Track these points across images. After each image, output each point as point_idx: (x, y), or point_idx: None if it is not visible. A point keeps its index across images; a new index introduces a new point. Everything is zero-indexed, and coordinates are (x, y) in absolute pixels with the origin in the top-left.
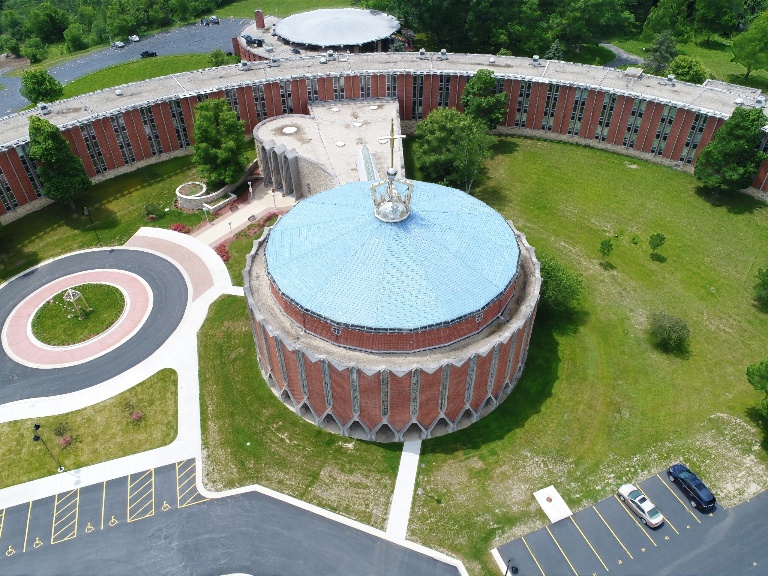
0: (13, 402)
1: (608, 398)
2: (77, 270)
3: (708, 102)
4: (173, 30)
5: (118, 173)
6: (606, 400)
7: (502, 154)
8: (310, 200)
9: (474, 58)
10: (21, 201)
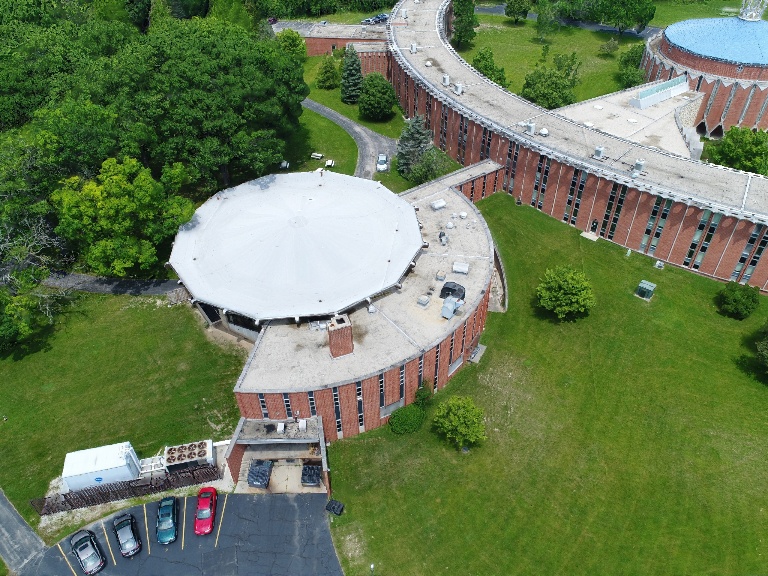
0: None
1: None
2: None
3: (425, 8)
4: None
5: None
6: None
7: None
8: (762, 59)
9: (428, 73)
10: None
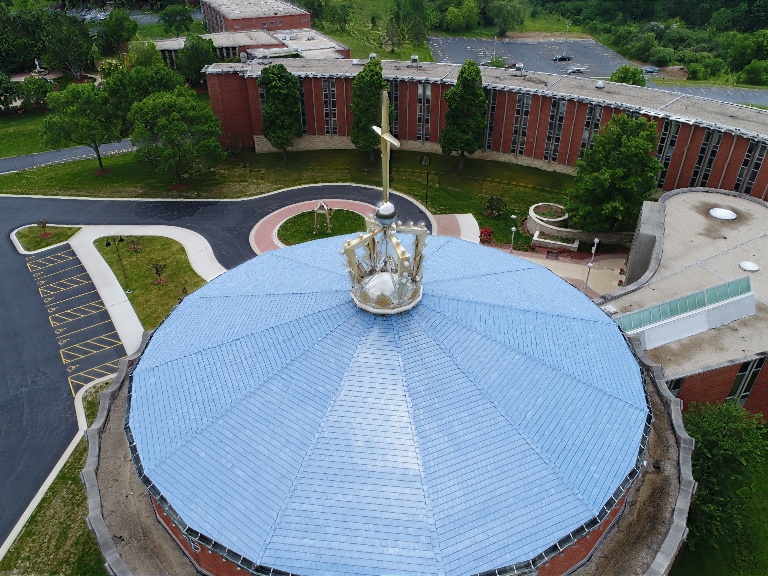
0: (206, 241)
1: None
2: None
3: None
4: None
5: (532, 164)
6: None
7: None
8: (454, 240)
9: None
10: (433, 138)
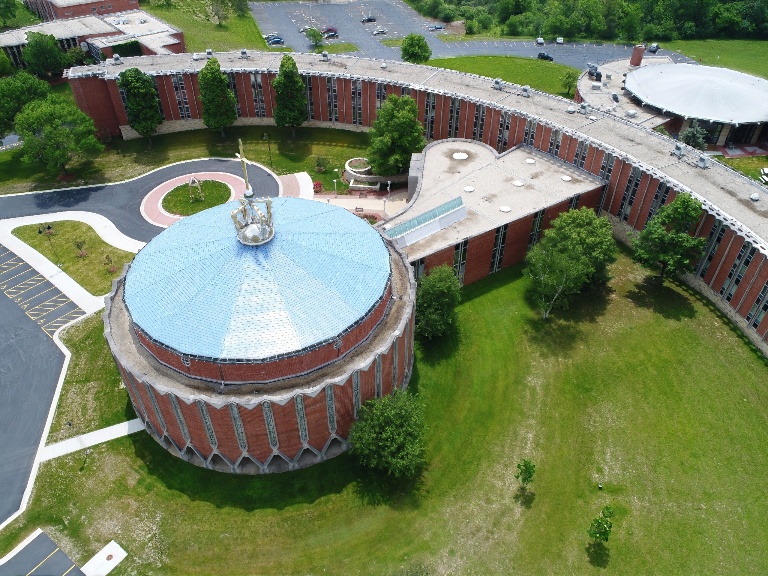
0: (107, 219)
1: (275, 571)
2: (239, 174)
3: None
4: (604, 44)
5: (346, 128)
6: (271, 570)
7: (654, 311)
8: (290, 199)
9: (741, 184)
10: (269, 114)
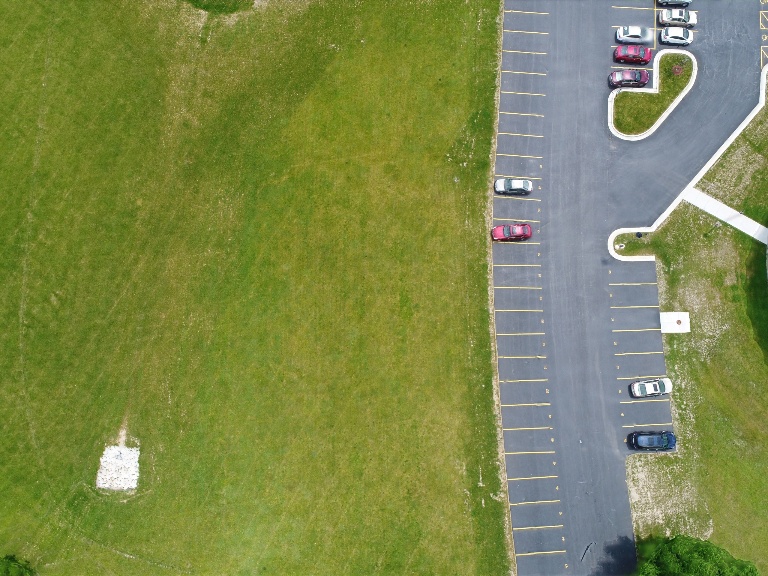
0: None
1: (761, 439)
2: None
3: None
4: None
5: None
6: (760, 435)
7: None
8: None
9: None
10: None
